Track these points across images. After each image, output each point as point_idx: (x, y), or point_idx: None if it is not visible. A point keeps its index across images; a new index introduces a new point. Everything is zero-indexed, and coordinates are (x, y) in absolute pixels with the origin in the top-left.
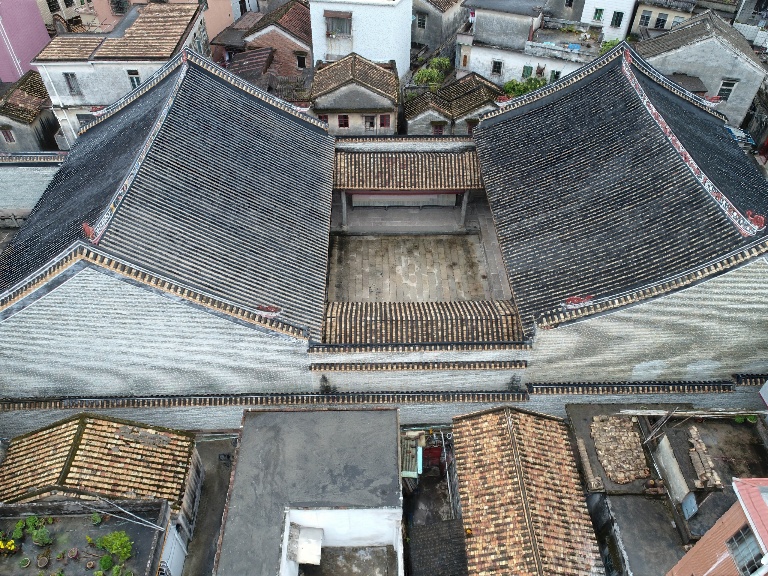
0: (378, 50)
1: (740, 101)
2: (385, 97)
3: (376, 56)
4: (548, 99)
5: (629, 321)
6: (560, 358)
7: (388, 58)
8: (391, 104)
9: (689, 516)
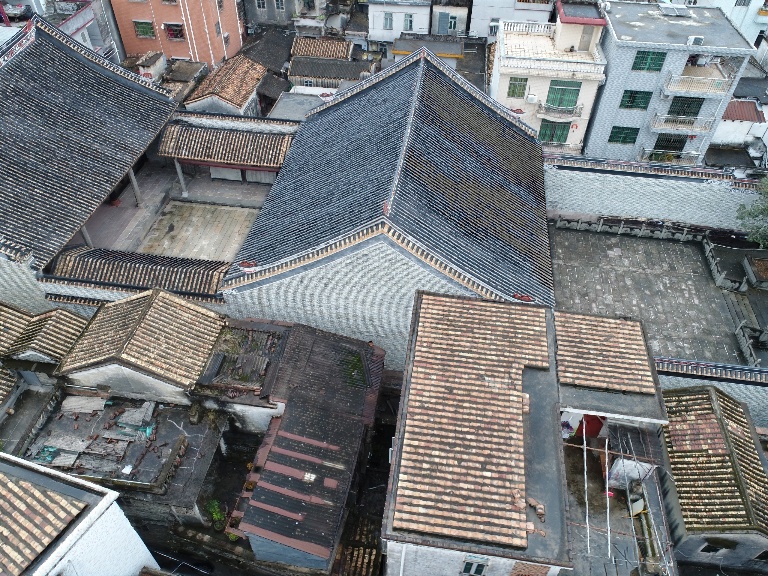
0: None
1: None
2: None
3: None
4: None
5: None
6: None
7: None
8: None
9: (166, 63)
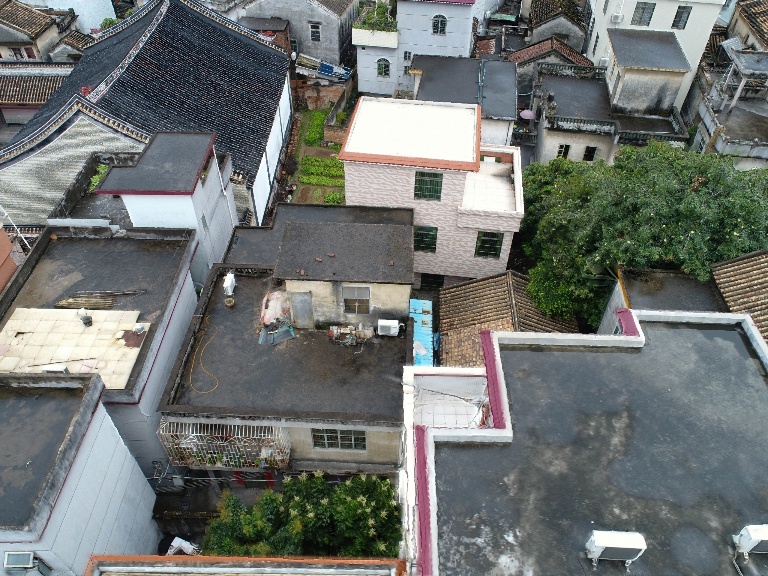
0: (64, 1)
1: (330, 42)
2: (21, 32)
3: (64, 6)
4: (129, 31)
5: (33, 173)
6: (10, 207)
7: (74, 8)
8: (29, 38)
9: None
